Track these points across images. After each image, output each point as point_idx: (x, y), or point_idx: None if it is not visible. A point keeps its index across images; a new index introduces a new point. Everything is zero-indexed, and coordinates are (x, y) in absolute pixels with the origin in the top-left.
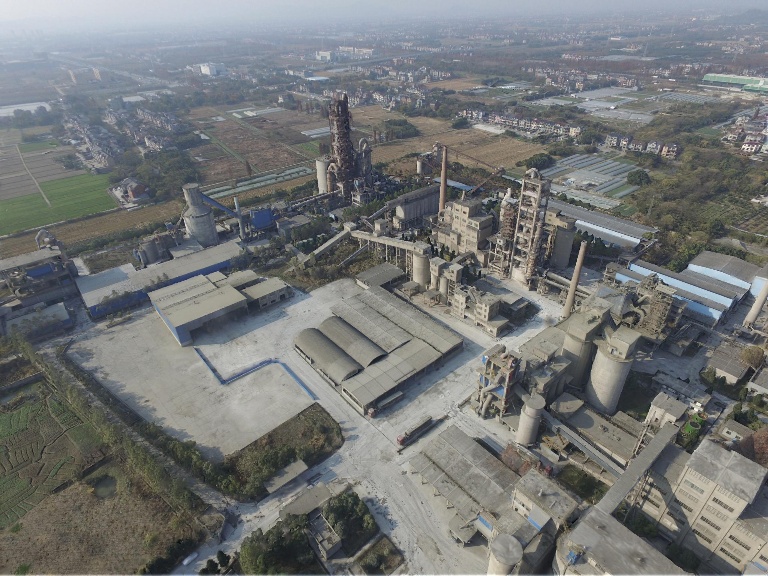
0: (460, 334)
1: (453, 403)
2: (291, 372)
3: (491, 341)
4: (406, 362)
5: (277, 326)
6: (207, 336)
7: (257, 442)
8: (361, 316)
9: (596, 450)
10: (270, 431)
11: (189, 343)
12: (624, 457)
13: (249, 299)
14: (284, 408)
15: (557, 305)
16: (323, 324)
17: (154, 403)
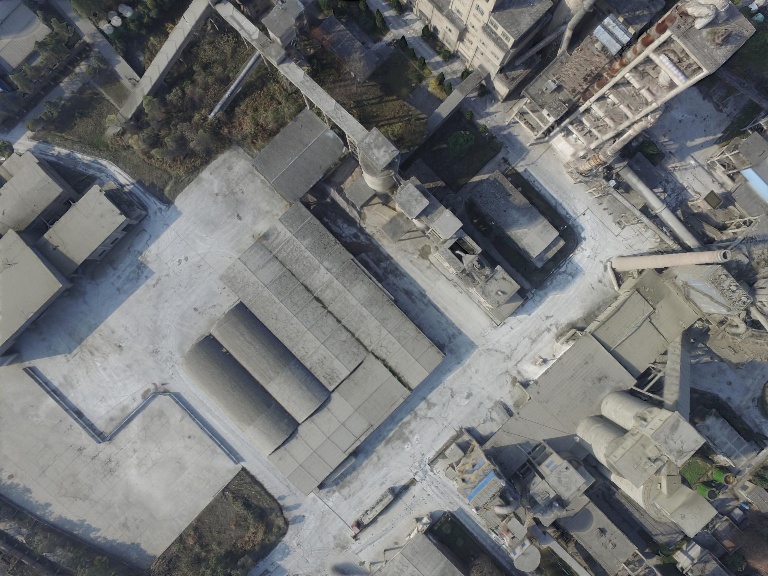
0: (441, 313)
1: (422, 458)
2: (193, 412)
3: (488, 328)
4: (358, 414)
5: (142, 306)
6: (35, 337)
7: (182, 536)
8: (278, 305)
9: (582, 570)
10: (193, 522)
11: (13, 358)
12: (611, 572)
13: (67, 266)
14: (201, 479)
15: (613, 227)
16: (217, 331)
17: (22, 480)
